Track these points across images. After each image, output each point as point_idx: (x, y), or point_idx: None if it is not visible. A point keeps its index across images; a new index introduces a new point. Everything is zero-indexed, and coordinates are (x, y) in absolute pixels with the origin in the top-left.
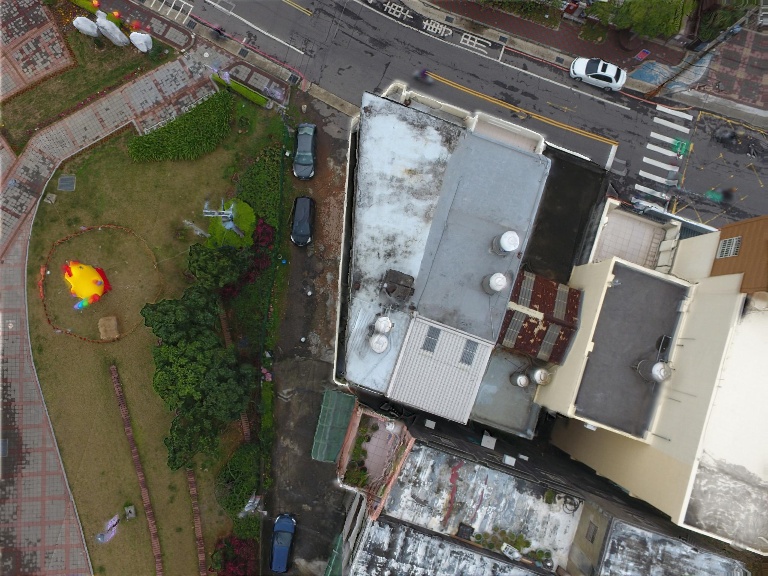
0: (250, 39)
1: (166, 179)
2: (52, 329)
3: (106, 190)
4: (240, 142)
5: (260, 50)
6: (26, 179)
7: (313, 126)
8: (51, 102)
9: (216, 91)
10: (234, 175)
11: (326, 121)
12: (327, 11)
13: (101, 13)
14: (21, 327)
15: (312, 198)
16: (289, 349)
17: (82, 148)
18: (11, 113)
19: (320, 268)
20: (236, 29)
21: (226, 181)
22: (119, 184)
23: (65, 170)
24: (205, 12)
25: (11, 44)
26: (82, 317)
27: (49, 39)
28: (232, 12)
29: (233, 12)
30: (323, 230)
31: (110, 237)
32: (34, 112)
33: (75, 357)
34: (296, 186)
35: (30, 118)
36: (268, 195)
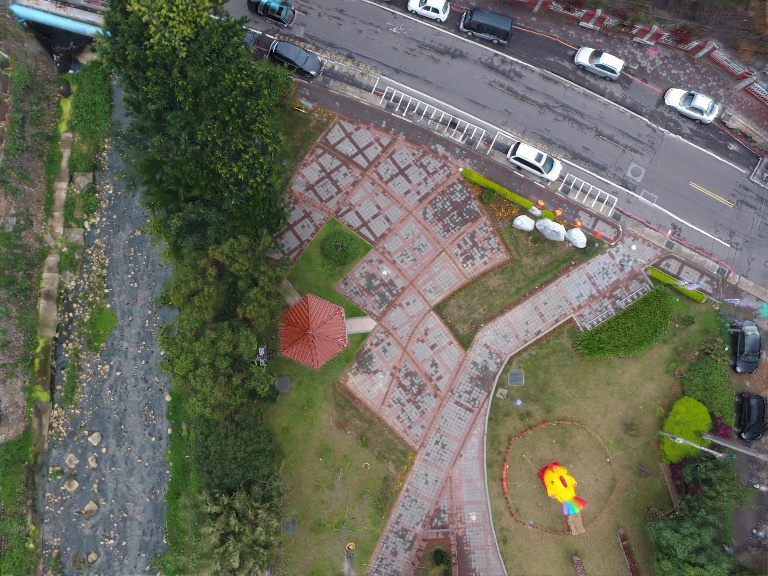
0: (675, 231)
1: (617, 377)
2: (514, 521)
3: (559, 387)
4: (679, 337)
5: (686, 242)
6: (476, 374)
7: (755, 324)
8: (493, 297)
9: (650, 285)
10: (677, 370)
11: (756, 313)
12: (748, 203)
13: (537, 210)
14: (483, 519)
15: (758, 395)
16: (741, 540)
17: (528, 343)
18: (456, 309)
19: (763, 460)
20: (661, 221)
21: (669, 376)
22: (573, 382)
23: (514, 365)
24: (630, 204)
25: (449, 239)
26: (541, 509)
27: (484, 234)
28: (656, 204)
29: (657, 204)
30: (763, 423)
31: (563, 432)
32: (478, 307)
33: (538, 548)
34: (733, 379)
35: (474, 313)
36: (723, 395)
